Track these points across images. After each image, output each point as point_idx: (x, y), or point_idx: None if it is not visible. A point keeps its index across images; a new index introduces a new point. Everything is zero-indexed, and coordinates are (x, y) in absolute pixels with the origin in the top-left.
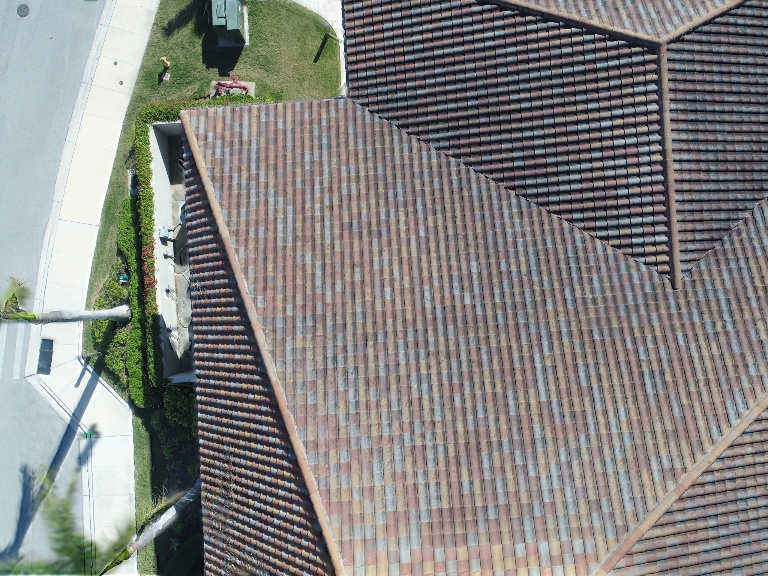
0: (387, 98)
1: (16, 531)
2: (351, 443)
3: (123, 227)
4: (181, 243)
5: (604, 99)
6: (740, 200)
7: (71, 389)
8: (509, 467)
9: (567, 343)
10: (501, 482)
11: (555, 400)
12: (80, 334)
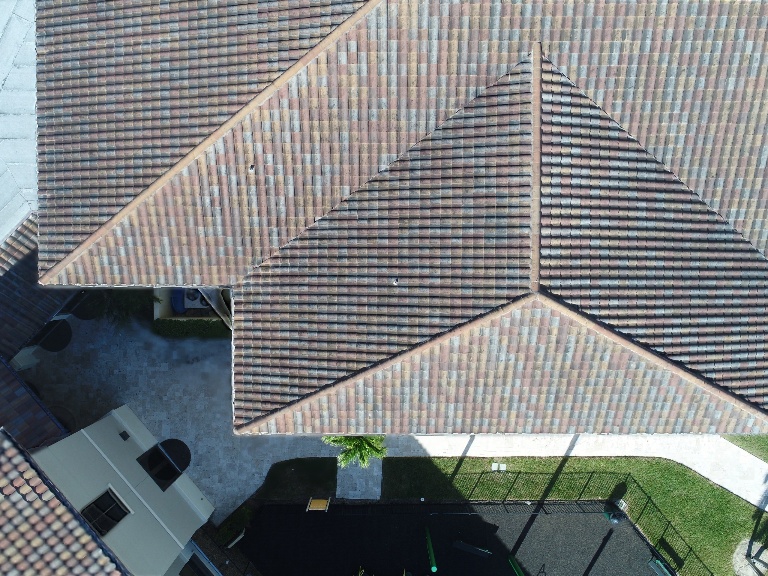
0: (766, 282)
1: None
2: None
3: None
4: None
5: (585, 247)
6: (450, 139)
7: None
8: None
9: None
10: None
11: None
12: None
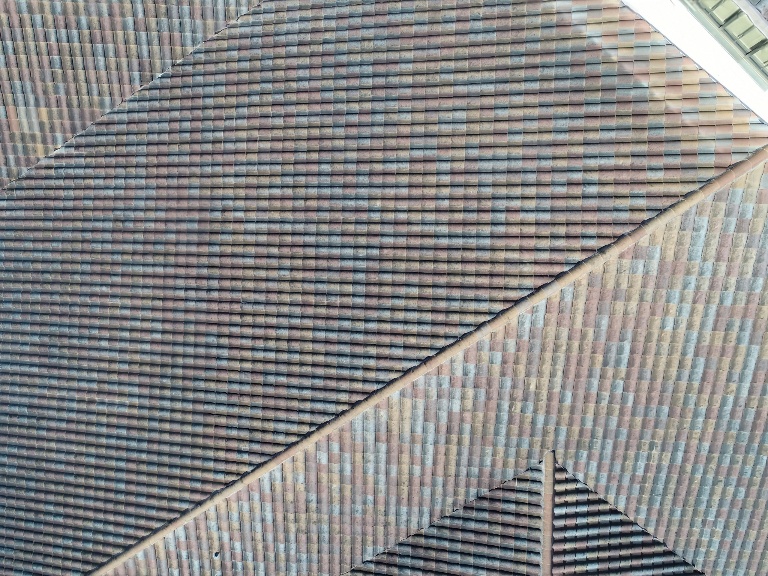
0: None
1: None
2: None
3: None
4: None
5: None
6: (445, 539)
7: None
8: None
9: (704, 406)
10: None
11: (744, 346)
12: None
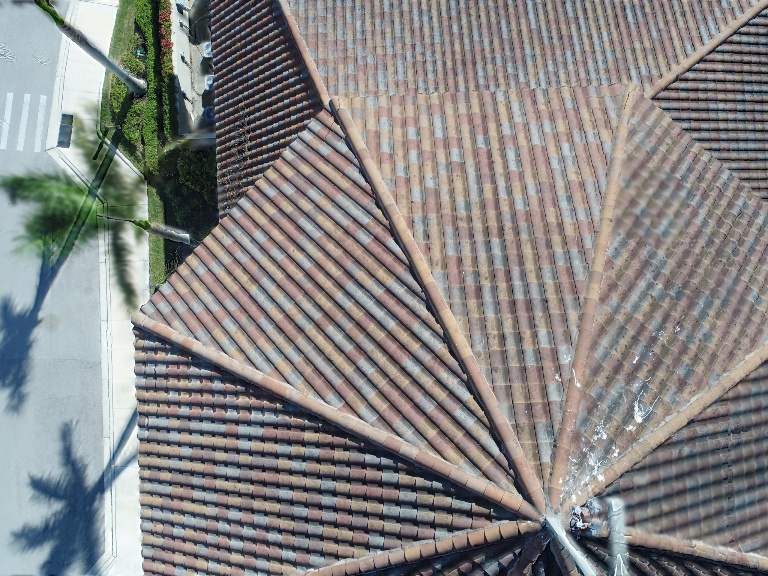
0: None
1: (36, 295)
2: (358, 59)
3: (141, 4)
4: (196, 15)
5: None
6: None
7: (89, 161)
8: (501, 75)
9: None
10: (494, 86)
11: (544, 27)
12: (99, 108)
